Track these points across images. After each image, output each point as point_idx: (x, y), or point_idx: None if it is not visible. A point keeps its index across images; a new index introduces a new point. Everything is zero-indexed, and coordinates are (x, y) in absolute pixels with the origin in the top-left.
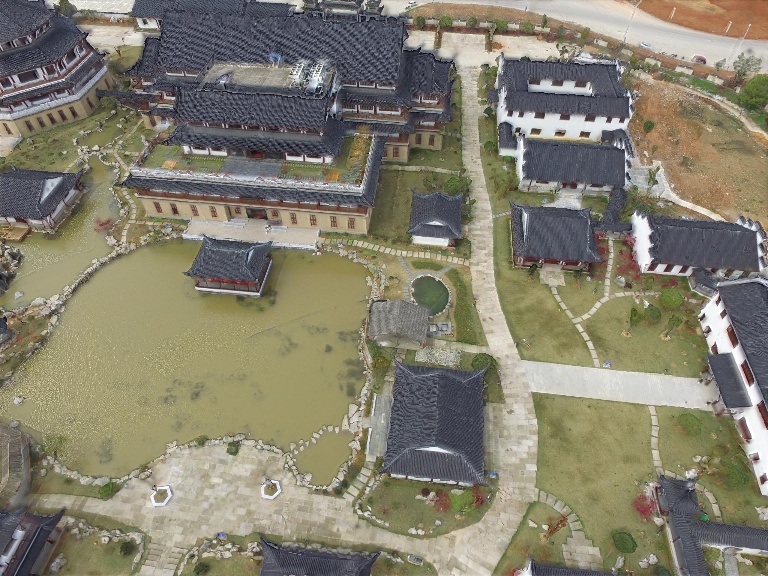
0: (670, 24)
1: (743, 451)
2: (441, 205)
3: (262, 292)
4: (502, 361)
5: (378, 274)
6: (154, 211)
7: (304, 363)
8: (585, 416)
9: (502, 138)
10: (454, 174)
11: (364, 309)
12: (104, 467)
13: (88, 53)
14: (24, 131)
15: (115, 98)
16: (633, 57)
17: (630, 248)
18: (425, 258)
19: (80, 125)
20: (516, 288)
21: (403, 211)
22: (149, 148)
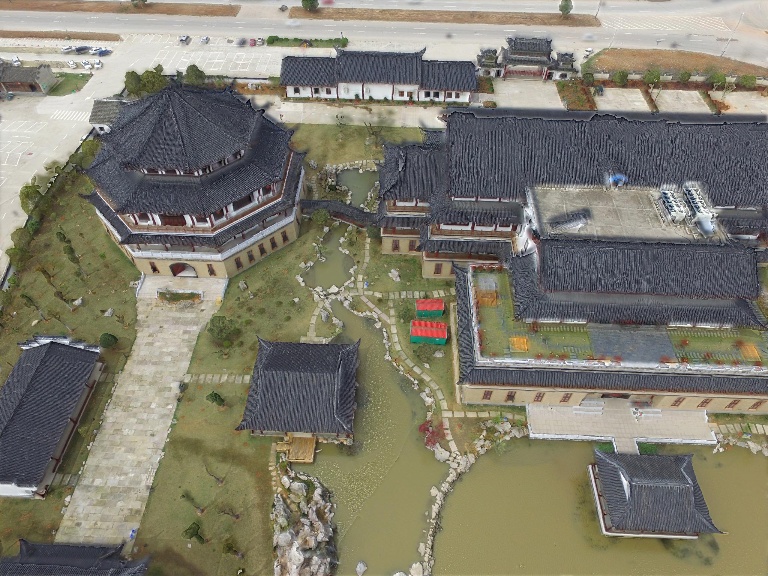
0: None
1: None
2: None
3: None
4: None
5: None
6: (478, 398)
7: None
8: None
9: None
10: None
11: None
12: None
13: (289, 155)
14: (231, 270)
15: (325, 210)
16: None
17: None
18: None
19: (292, 252)
20: None
21: None
22: (476, 317)
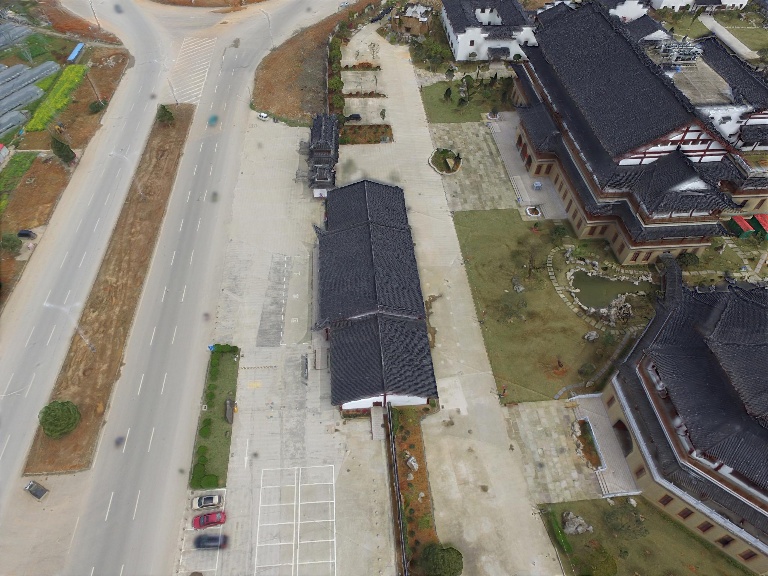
0: None
1: (728, 11)
2: None
3: None
4: (744, 58)
5: None
6: None
7: None
8: (749, 40)
9: None
10: None
11: None
12: None
13: None
14: None
15: None
16: (375, 8)
17: None
18: None
19: None
20: None
21: None
22: None
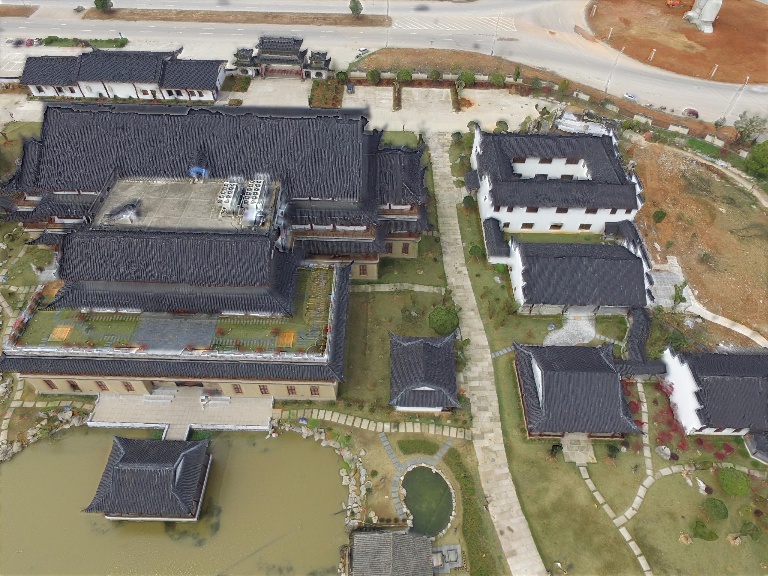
0: (650, 67)
1: None
2: (429, 358)
3: (200, 511)
4: None
5: (356, 465)
6: (46, 388)
7: None
8: None
9: (490, 241)
10: (437, 292)
11: (341, 527)
12: None
13: None
14: None
15: None
16: (619, 113)
17: (665, 394)
18: (414, 433)
19: None
20: (536, 473)
21: (379, 357)
22: (31, 308)
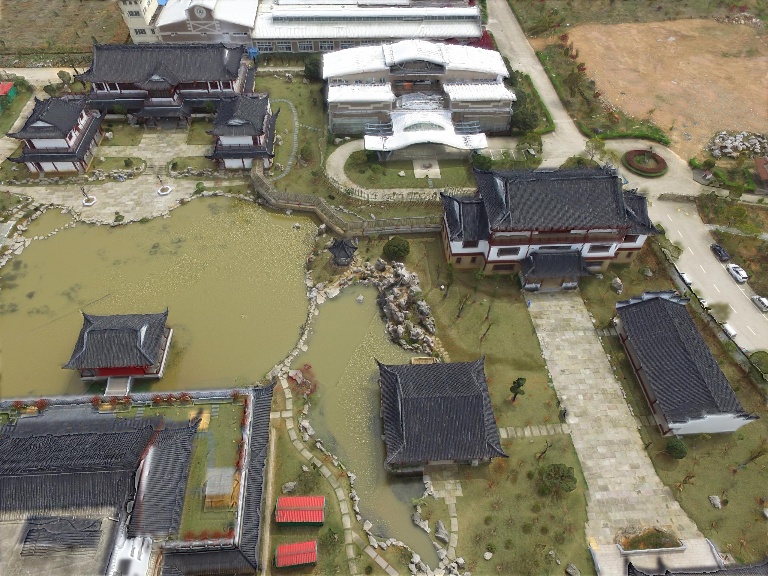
0: None
1: None
2: None
3: None
4: None
5: None
6: None
7: (59, 283)
8: None
9: None
10: None
11: None
12: (212, 202)
13: None
14: None
15: None
16: None
17: None
18: None
19: None
20: None
21: None
22: None
